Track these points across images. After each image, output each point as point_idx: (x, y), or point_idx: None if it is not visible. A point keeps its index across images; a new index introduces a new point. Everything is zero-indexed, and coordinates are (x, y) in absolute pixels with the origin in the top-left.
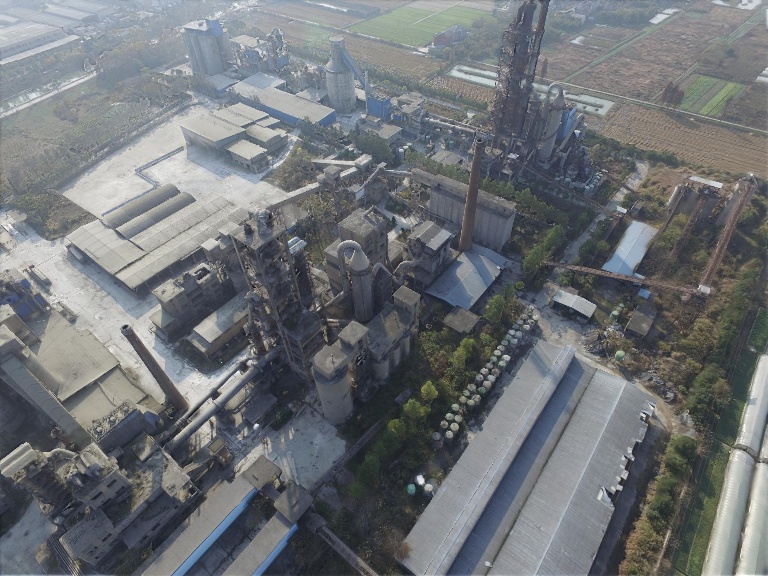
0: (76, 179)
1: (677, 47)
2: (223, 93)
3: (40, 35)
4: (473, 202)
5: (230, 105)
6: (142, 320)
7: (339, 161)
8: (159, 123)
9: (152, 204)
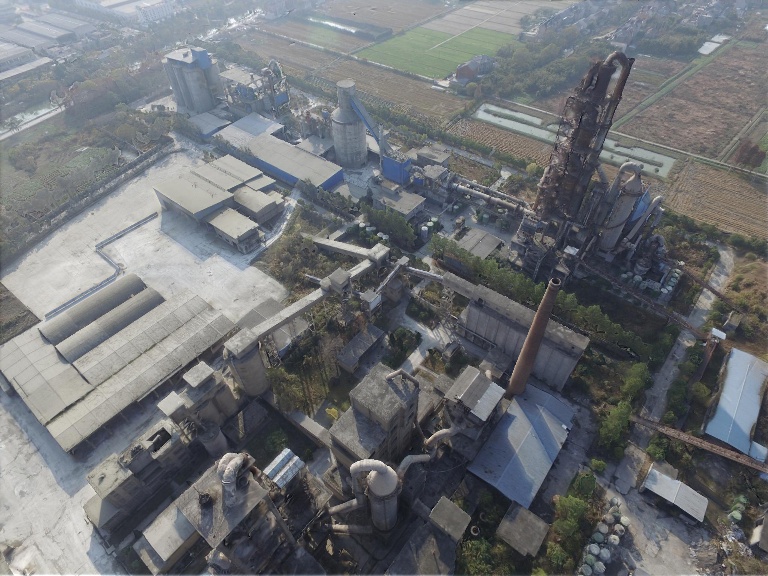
0: (21, 257)
1: (737, 85)
2: (210, 137)
3: (6, 58)
4: (535, 347)
5: (218, 153)
6: (78, 499)
7: (348, 245)
8: (131, 177)
9: (108, 305)
